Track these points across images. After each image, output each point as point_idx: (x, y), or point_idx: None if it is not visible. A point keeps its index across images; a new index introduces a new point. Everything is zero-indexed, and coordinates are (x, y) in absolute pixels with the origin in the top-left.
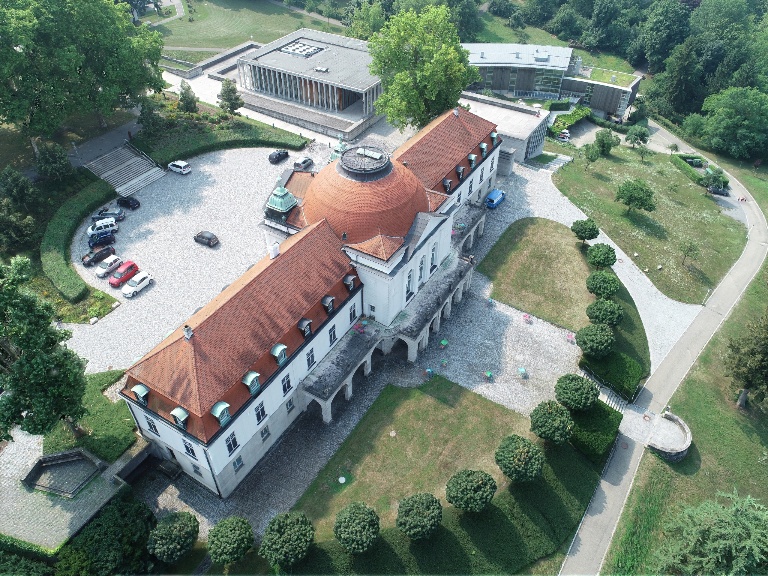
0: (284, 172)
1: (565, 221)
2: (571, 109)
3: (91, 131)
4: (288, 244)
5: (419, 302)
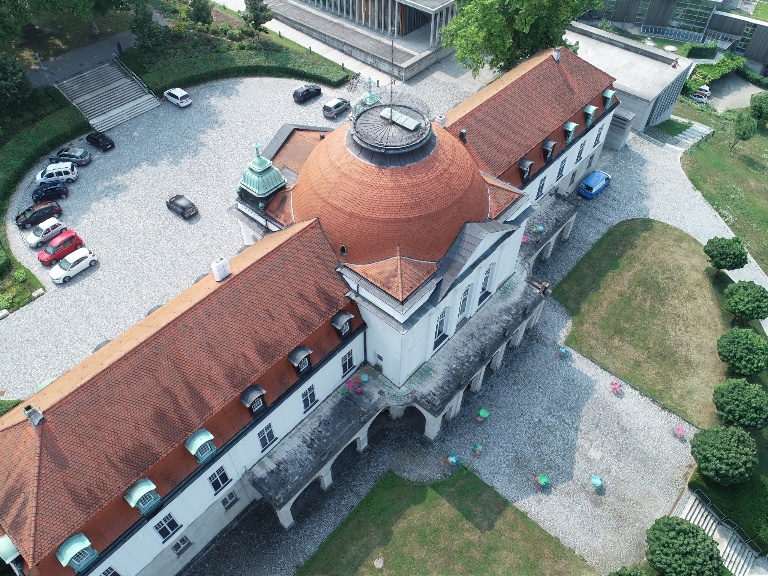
0: (281, 129)
1: (693, 230)
2: (717, 57)
3: (78, 38)
4: (253, 254)
5: (454, 350)
